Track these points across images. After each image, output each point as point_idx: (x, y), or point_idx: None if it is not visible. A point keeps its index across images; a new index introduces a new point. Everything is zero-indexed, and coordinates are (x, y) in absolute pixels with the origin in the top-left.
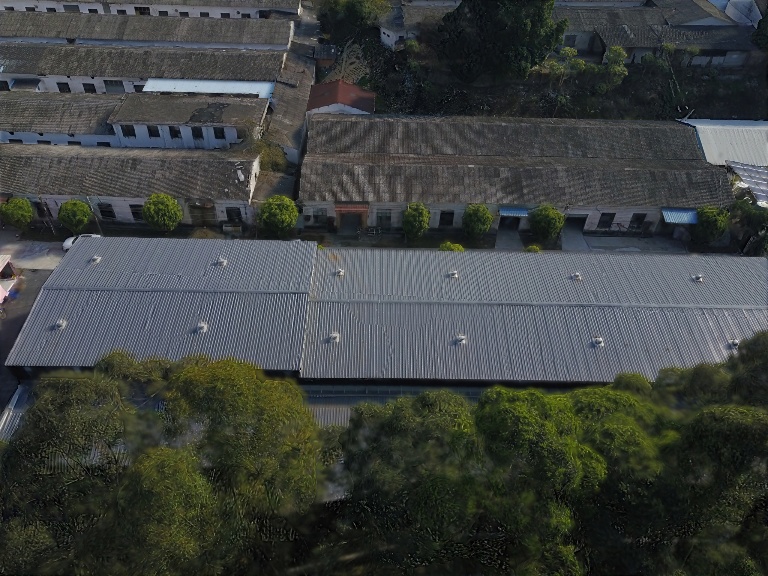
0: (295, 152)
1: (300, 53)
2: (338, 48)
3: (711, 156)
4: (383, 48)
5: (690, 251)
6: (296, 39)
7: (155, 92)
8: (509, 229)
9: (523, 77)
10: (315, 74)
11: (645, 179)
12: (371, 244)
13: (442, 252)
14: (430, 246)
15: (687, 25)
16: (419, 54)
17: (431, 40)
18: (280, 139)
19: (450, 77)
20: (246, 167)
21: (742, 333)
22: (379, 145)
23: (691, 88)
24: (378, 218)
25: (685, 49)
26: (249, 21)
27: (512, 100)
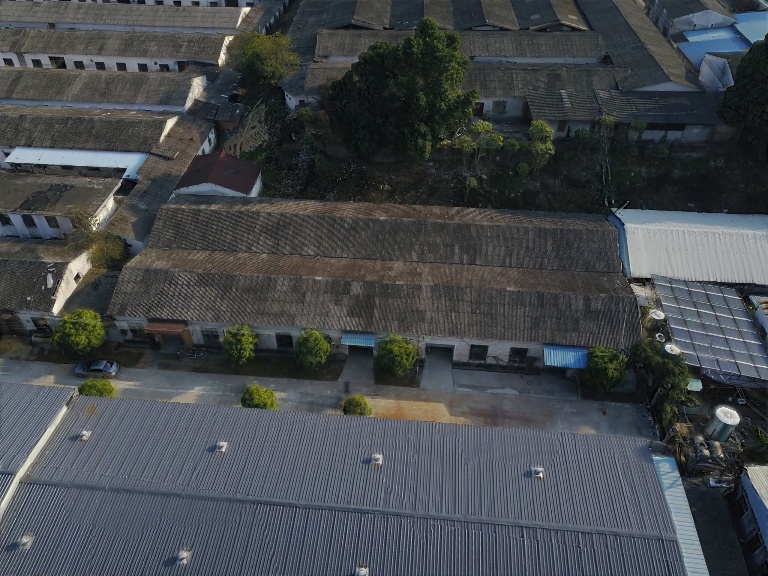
0: (140, 244)
1: (199, 114)
2: (248, 107)
3: (637, 265)
4: (285, 112)
5: (583, 397)
6: (203, 96)
7: (17, 163)
8: (363, 354)
9: (422, 157)
10: (216, 137)
11: (530, 304)
12: (193, 367)
13: (226, 408)
14: (261, 374)
15: (641, 90)
16: (314, 123)
17: (335, 105)
18: (122, 229)
19: (349, 150)
20: (59, 270)
21: (566, 574)
22: (230, 241)
23: (638, 168)
24: (205, 336)
25: (629, 123)
26: (148, 78)
27: (418, 179)
